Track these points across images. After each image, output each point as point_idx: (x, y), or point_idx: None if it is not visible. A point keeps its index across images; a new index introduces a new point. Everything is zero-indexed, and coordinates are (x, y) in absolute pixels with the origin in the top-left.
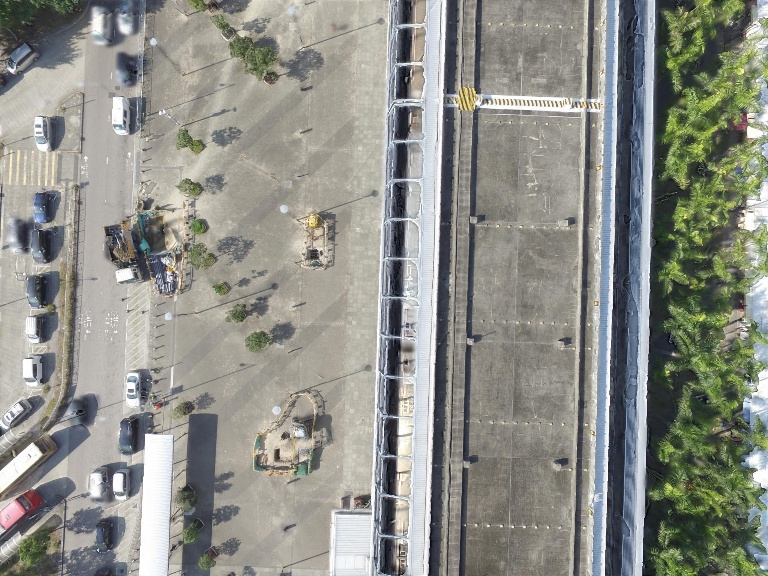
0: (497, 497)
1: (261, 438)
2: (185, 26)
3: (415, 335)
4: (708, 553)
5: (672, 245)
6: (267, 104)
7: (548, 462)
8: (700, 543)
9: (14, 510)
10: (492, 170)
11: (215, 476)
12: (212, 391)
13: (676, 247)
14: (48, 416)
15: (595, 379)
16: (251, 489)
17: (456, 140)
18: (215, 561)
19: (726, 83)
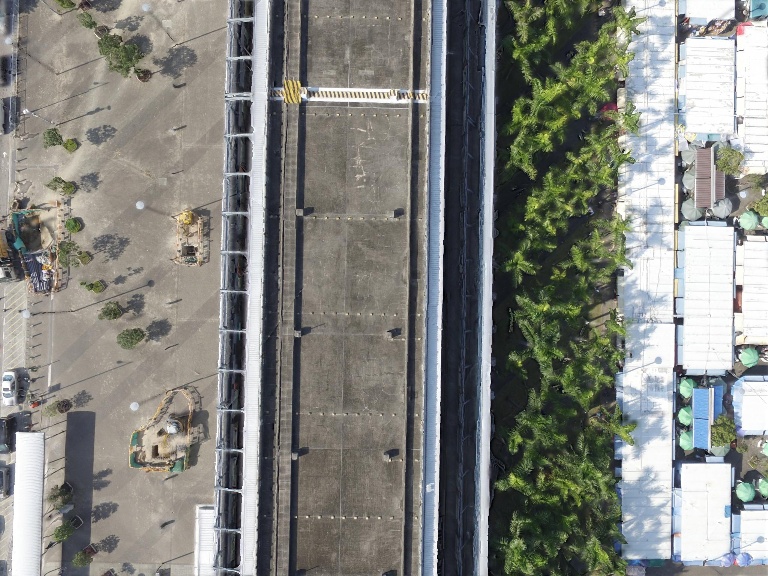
0: (328, 489)
1: (139, 435)
2: (58, 25)
3: (246, 328)
4: (560, 542)
5: (523, 235)
6: (141, 102)
7: (379, 453)
8: (553, 532)
9: None
10: (320, 162)
11: (93, 473)
12: (90, 389)
13: (527, 237)
14: None
15: (423, 369)
16: (129, 486)
17: (283, 133)
18: (91, 558)
19: (577, 72)
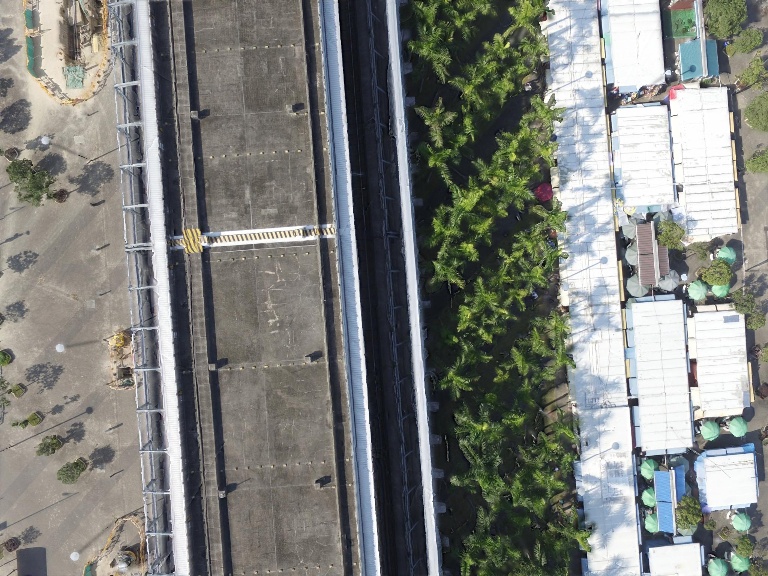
0: None
1: (92, 567)
2: None
3: None
4: None
5: (457, 347)
6: (60, 223)
7: None
8: None
9: None
10: (230, 310)
11: None
12: (37, 524)
13: (462, 348)
14: None
15: (356, 518)
16: None
17: (187, 284)
18: None
19: (499, 171)
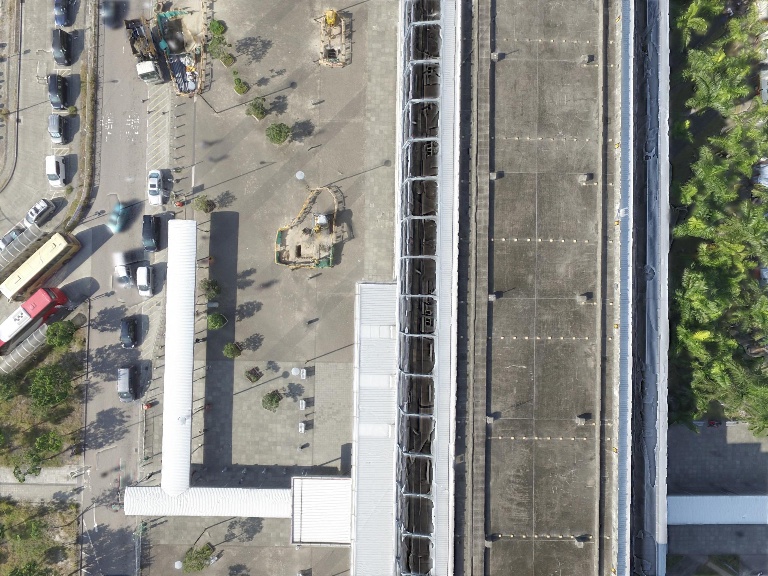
0: (524, 212)
1: (282, 234)
2: None
3: None
4: (732, 297)
5: None
6: None
7: (573, 177)
8: (724, 289)
9: (40, 298)
10: None
11: (237, 273)
12: (233, 189)
13: None
14: (71, 216)
15: (618, 92)
16: (273, 285)
17: None
18: (239, 352)
19: None
